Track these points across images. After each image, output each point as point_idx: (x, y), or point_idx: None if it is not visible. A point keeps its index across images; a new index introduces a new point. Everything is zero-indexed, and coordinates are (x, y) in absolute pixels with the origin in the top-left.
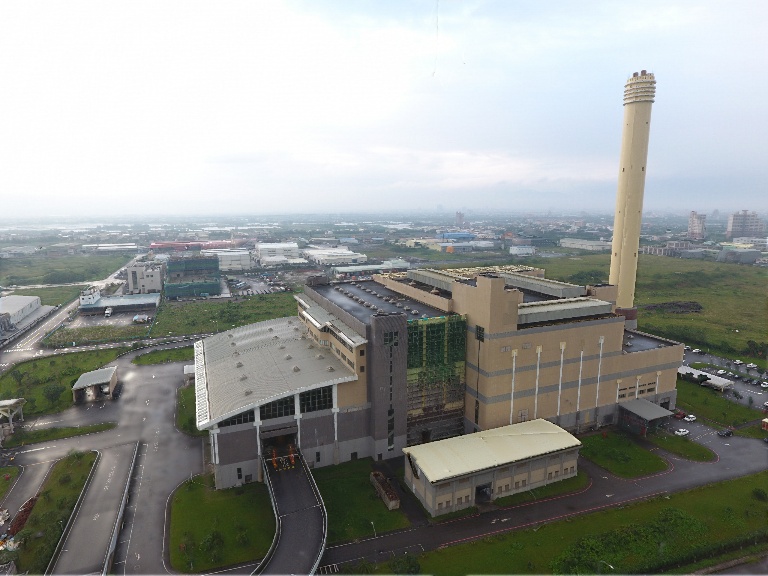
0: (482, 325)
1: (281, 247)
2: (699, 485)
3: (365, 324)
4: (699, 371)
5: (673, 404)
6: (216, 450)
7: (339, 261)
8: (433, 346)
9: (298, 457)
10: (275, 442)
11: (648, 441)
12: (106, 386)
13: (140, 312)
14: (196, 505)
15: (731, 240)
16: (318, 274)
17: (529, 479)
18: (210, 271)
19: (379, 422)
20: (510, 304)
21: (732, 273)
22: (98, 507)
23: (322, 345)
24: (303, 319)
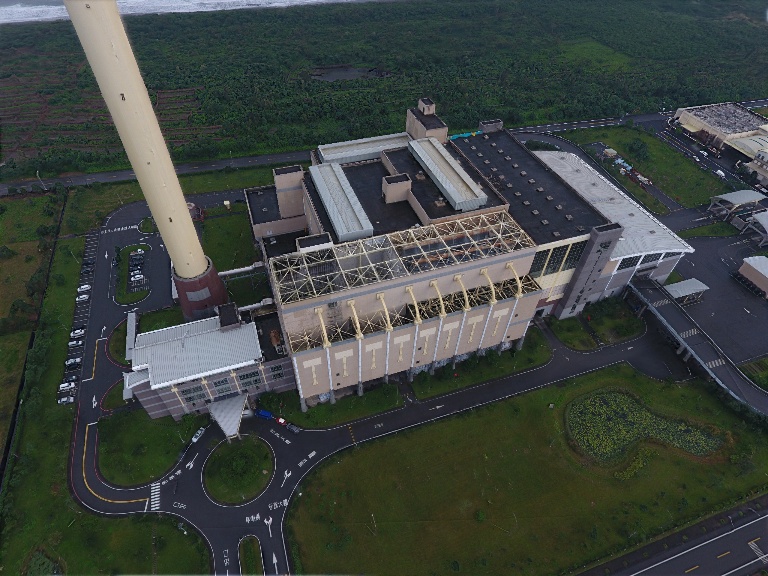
0: None
1: None
2: None
3: None
4: None
5: None
6: None
7: None
8: None
9: None
10: None
11: None
12: None
13: None
14: None
15: None
16: None
17: None
18: None
19: None
20: None
21: None
22: None
23: None
24: None
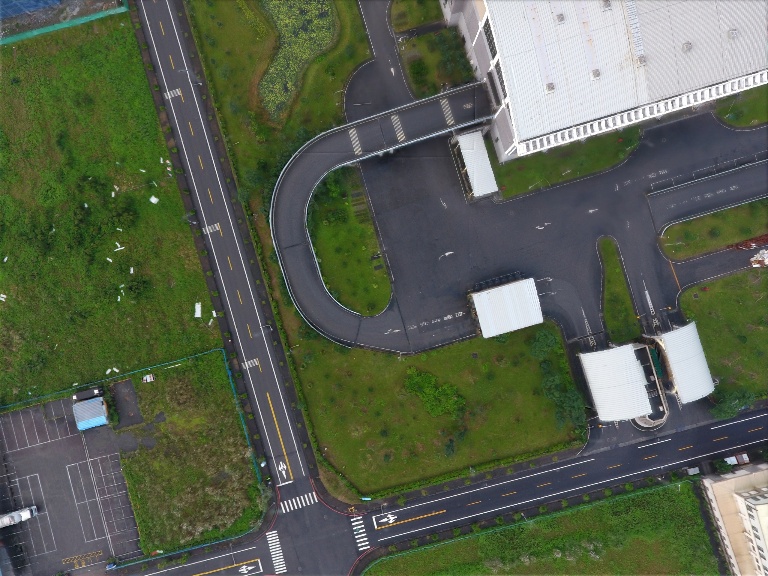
0: None
1: None
2: None
3: None
4: None
5: None
6: None
7: None
8: None
9: None
10: None
11: None
12: None
13: (3, 451)
14: (763, 103)
15: None
16: None
17: None
18: None
19: None
20: None
21: None
22: (764, 180)
23: None
24: None
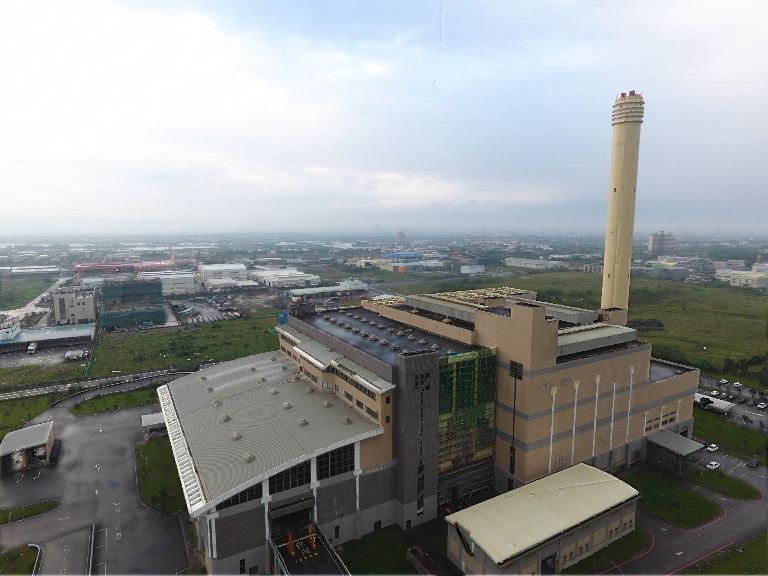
0: (520, 361)
1: (227, 269)
2: (762, 531)
3: (390, 365)
4: (697, 394)
5: (690, 433)
6: (213, 540)
7: (291, 283)
8: (464, 387)
9: (318, 538)
10: (283, 518)
11: (685, 479)
12: (41, 449)
13: (72, 347)
14: None
15: (656, 258)
16: (272, 297)
17: (592, 542)
18: (152, 296)
19: (408, 482)
20: (550, 336)
21: (673, 290)
22: None
23: (324, 388)
24: (288, 355)
